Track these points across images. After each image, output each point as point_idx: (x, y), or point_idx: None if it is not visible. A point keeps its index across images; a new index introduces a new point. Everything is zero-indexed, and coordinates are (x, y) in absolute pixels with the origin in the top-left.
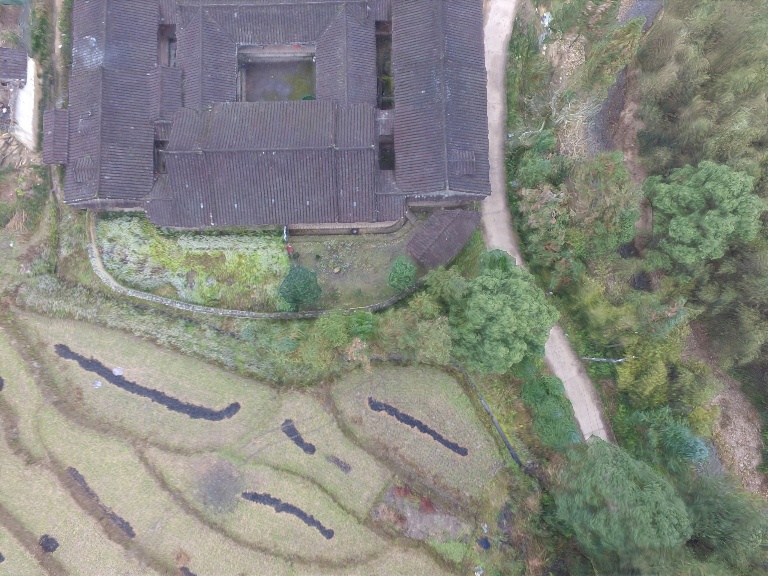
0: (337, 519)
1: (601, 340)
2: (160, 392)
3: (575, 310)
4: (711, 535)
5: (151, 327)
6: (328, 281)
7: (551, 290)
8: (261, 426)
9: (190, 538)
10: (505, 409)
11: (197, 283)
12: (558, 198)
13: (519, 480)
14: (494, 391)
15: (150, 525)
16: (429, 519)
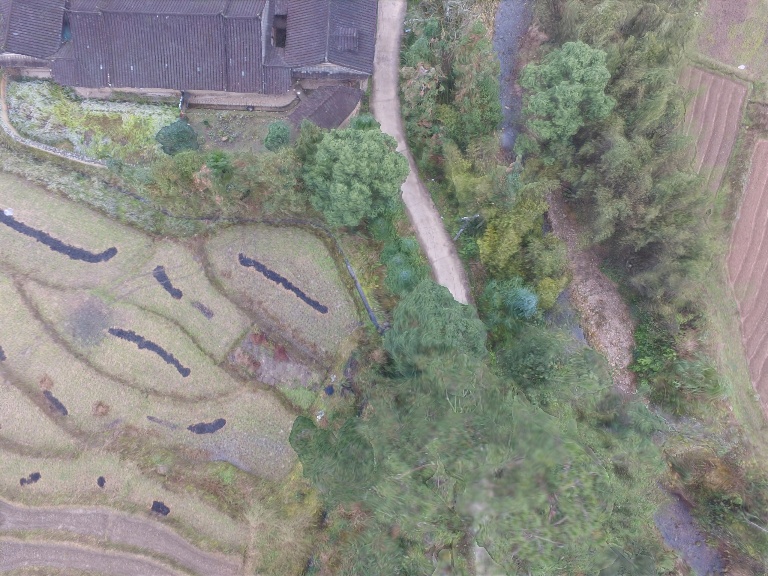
0: (195, 359)
1: (467, 216)
2: (45, 233)
3: (451, 194)
4: (524, 374)
5: (43, 174)
6: (216, 148)
7: (433, 177)
8: (134, 270)
9: (56, 365)
10: (367, 273)
11: (93, 141)
12: (428, 72)
13: (370, 336)
14: (358, 256)
15: (20, 350)
16: (282, 366)
